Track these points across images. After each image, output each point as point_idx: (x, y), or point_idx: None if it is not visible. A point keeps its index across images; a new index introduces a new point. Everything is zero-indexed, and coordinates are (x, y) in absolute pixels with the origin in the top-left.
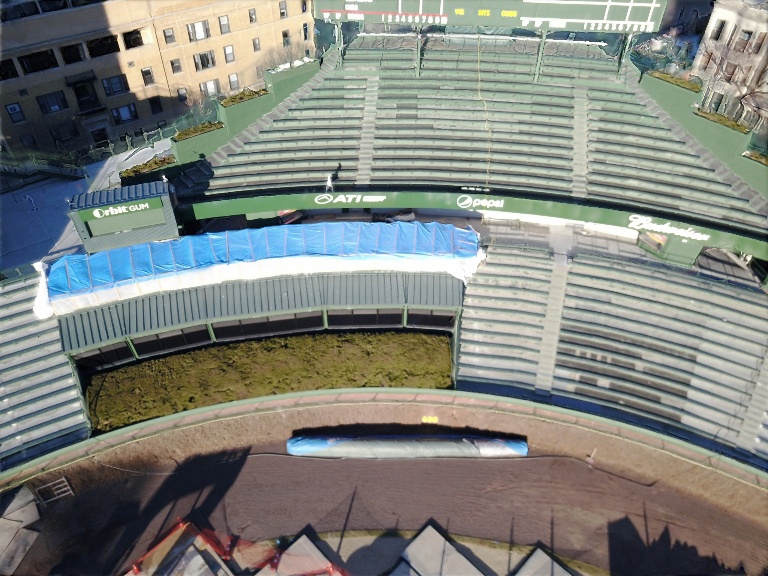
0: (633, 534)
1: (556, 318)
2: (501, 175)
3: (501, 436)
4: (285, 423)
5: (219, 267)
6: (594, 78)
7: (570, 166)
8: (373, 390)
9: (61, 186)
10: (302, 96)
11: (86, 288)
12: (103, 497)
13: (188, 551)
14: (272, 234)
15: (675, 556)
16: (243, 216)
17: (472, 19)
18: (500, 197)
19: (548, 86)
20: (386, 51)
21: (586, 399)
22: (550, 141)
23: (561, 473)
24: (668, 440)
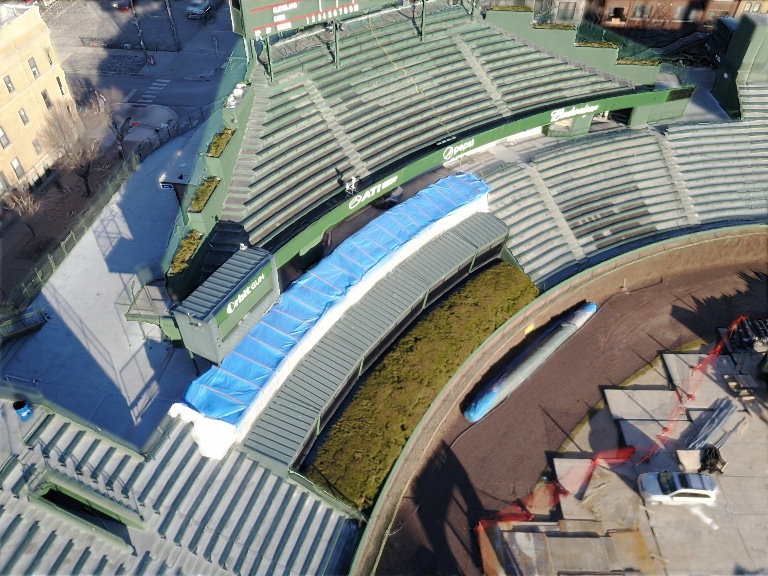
0: (685, 311)
1: (554, 207)
2: (453, 122)
3: (571, 310)
4: None
5: (339, 302)
6: (457, 25)
7: (487, 96)
8: (502, 327)
9: (30, 344)
10: (260, 122)
11: (256, 393)
12: (391, 572)
13: (506, 538)
14: (346, 252)
15: (711, 307)
16: (297, 254)
17: (376, 0)
18: (470, 138)
19: (435, 41)
20: (301, 54)
21: (608, 248)
22: (463, 83)
23: (621, 307)
24: (666, 242)
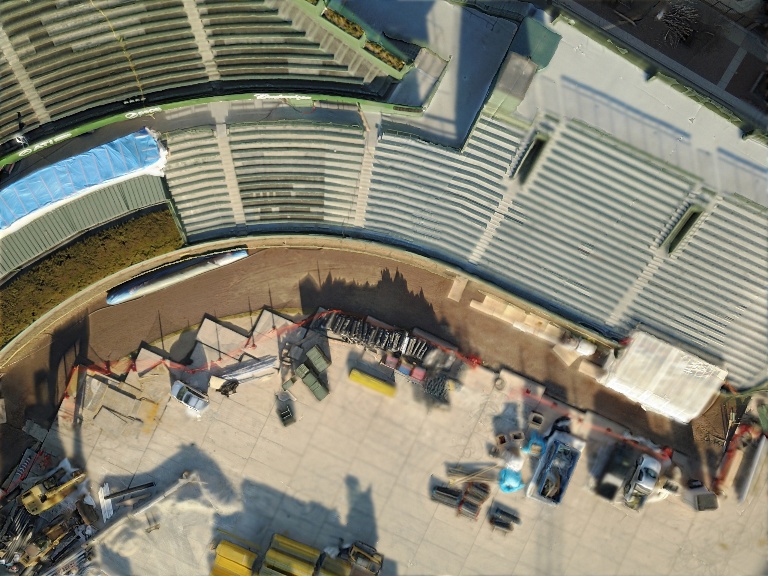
0: (312, 283)
1: (233, 177)
2: (149, 80)
3: (231, 248)
4: (98, 292)
5: None
6: None
7: (199, 54)
8: (138, 264)
9: None
10: None
11: None
12: (23, 369)
13: (87, 379)
14: (7, 197)
15: (334, 288)
16: None
17: None
18: (156, 106)
19: None
20: None
21: (267, 223)
22: (174, 34)
23: (270, 259)
24: None
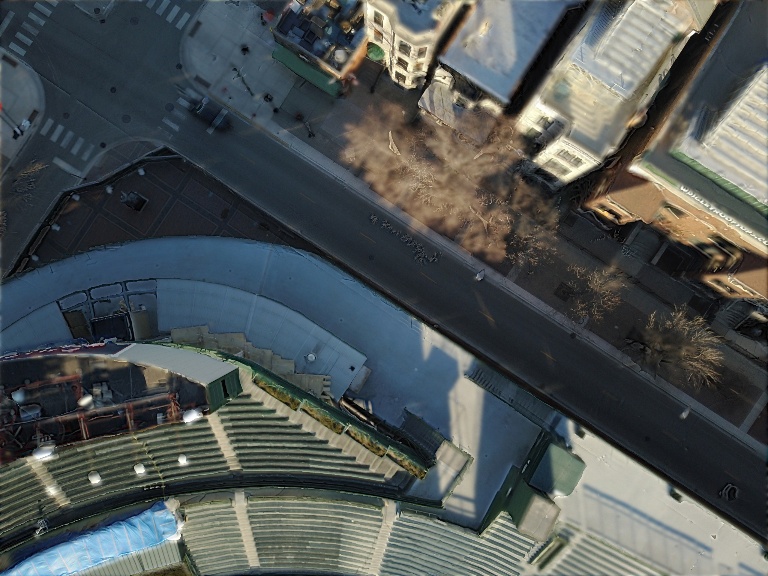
0: None
1: (249, 534)
2: None
3: None
4: None
5: None
6: None
7: (221, 451)
8: None
9: None
10: None
11: None
12: None
13: None
14: (24, 569)
15: None
16: None
17: None
18: None
19: None
20: None
21: (282, 567)
22: None
23: None
24: None
